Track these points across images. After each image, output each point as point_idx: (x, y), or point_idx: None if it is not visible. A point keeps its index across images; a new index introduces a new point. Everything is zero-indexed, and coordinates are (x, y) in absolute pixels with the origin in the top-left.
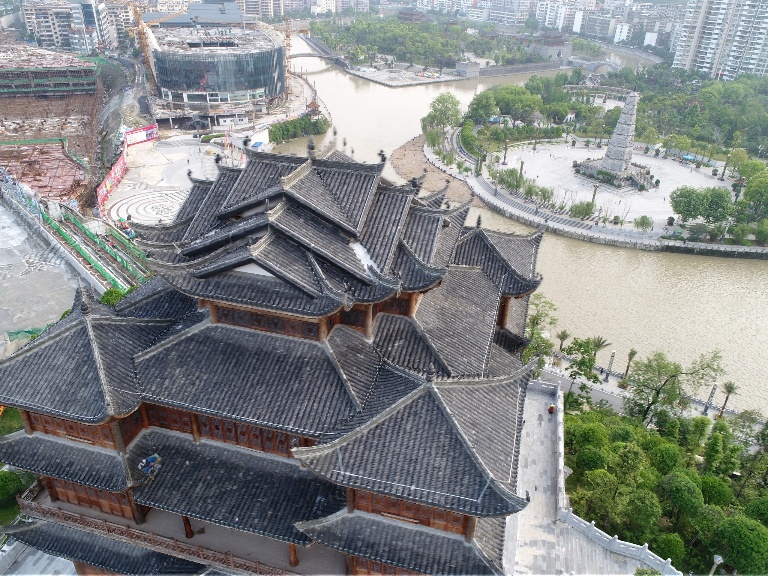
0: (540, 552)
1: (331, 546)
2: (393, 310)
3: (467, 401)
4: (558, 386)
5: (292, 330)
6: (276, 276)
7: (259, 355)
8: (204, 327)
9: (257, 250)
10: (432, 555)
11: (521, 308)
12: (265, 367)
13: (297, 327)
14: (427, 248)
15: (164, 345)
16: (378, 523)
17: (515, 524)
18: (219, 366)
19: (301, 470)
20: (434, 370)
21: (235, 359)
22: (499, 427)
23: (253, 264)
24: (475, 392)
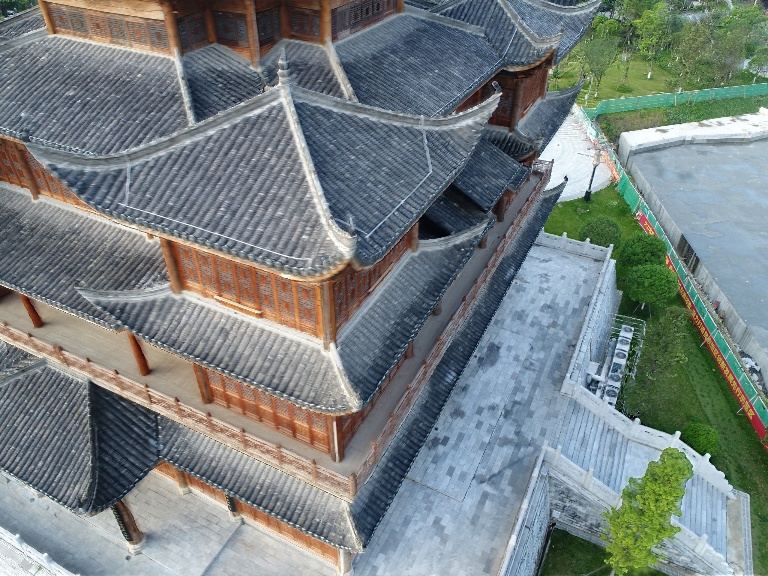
0: None
1: None
2: None
3: None
4: None
5: None
6: None
7: None
8: None
9: None
10: None
11: None
12: None
13: None
14: None
15: (414, 0)
16: None
17: None
18: None
19: None
20: None
21: None
22: None
23: None
24: None
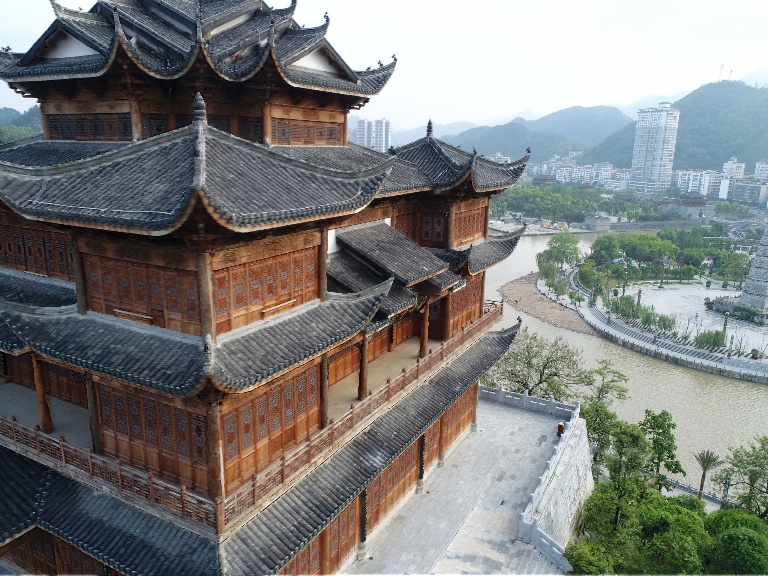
0: (474, 569)
1: (33, 344)
2: (249, 138)
3: (255, 165)
4: (576, 407)
5: (110, 132)
6: (78, 38)
7: (64, 153)
8: (34, 142)
9: (68, 16)
10: (150, 360)
11: (493, 254)
12: (60, 159)
13: (114, 126)
14: (287, 52)
15: None
16: (108, 326)
17: (451, 531)
18: (17, 162)
19: (75, 293)
20: (202, 103)
21: (38, 157)
22: (287, 194)
23: (61, 31)
24: (278, 167)
